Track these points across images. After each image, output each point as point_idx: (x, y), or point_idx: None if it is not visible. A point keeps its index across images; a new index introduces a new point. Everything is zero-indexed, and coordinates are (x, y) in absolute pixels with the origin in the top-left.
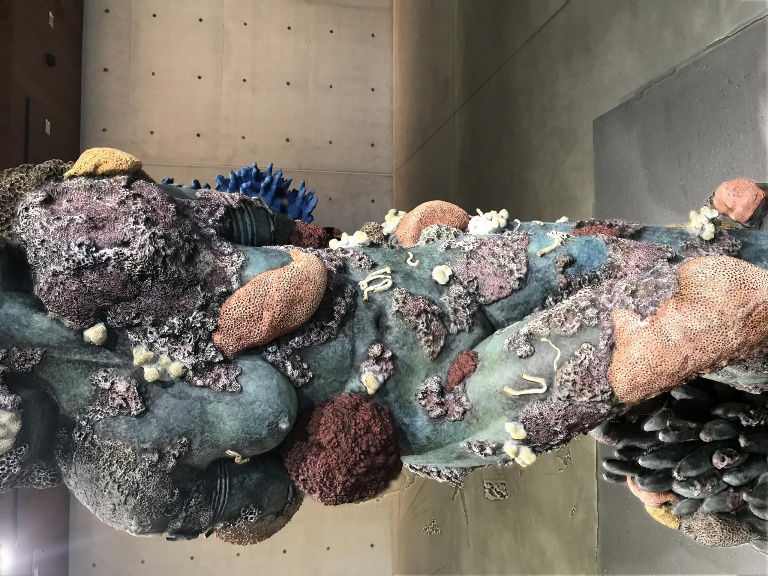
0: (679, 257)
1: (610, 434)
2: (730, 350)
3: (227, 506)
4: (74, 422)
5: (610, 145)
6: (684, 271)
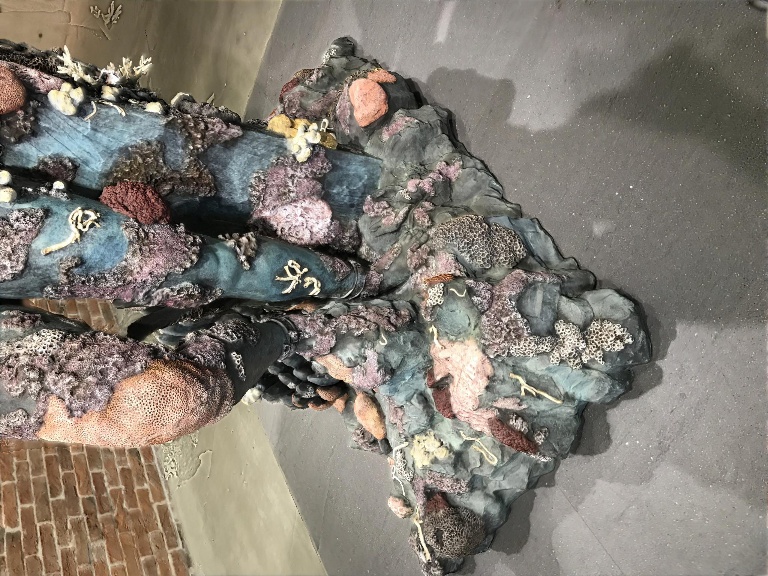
0: (203, 259)
1: None
2: None
3: None
4: None
5: None
6: (120, 389)
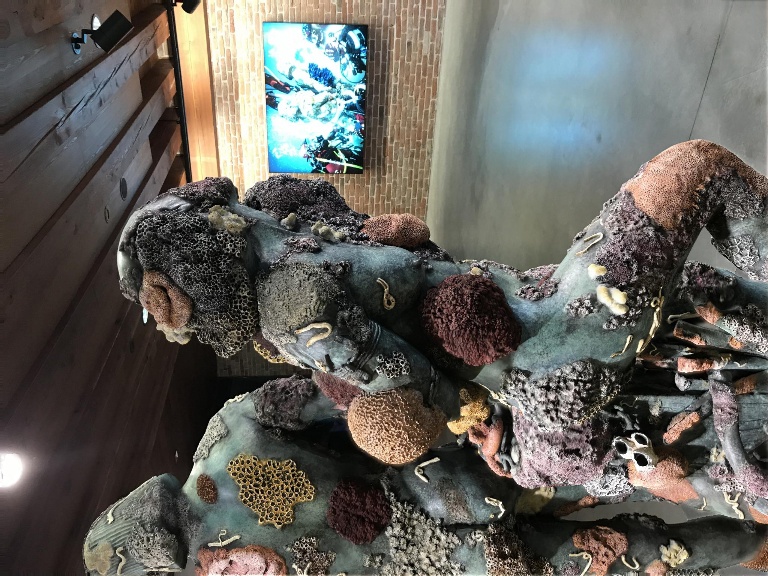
0: None
1: (757, 467)
2: (702, 165)
3: (381, 339)
4: (270, 265)
5: None
6: None
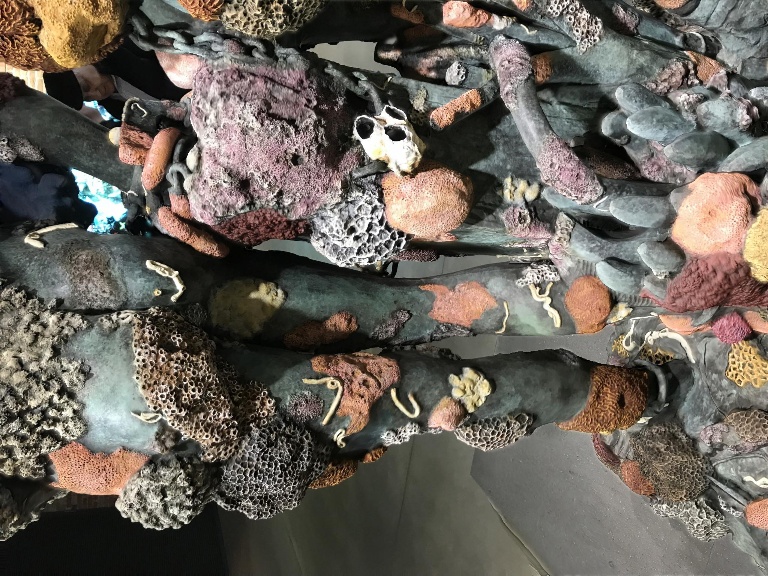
0: None
1: (567, 144)
2: None
3: None
4: None
5: (497, 472)
6: None
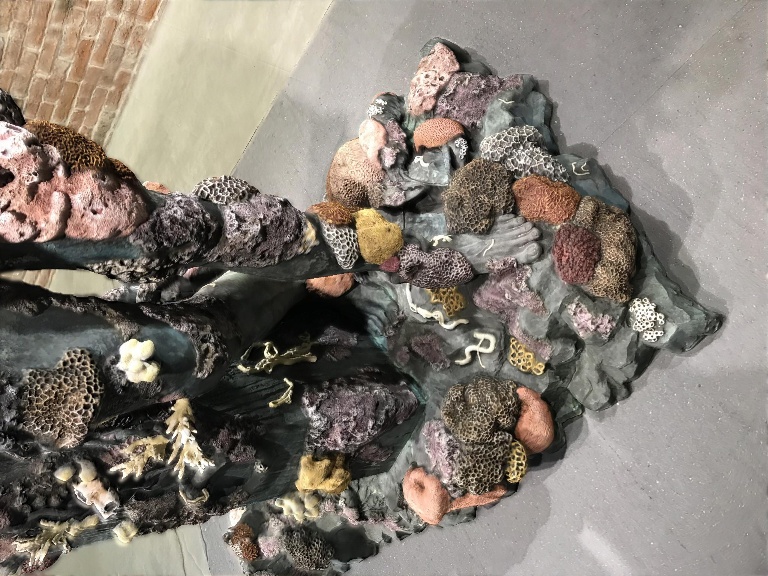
0: None
1: None
2: None
3: None
4: None
5: None
6: None
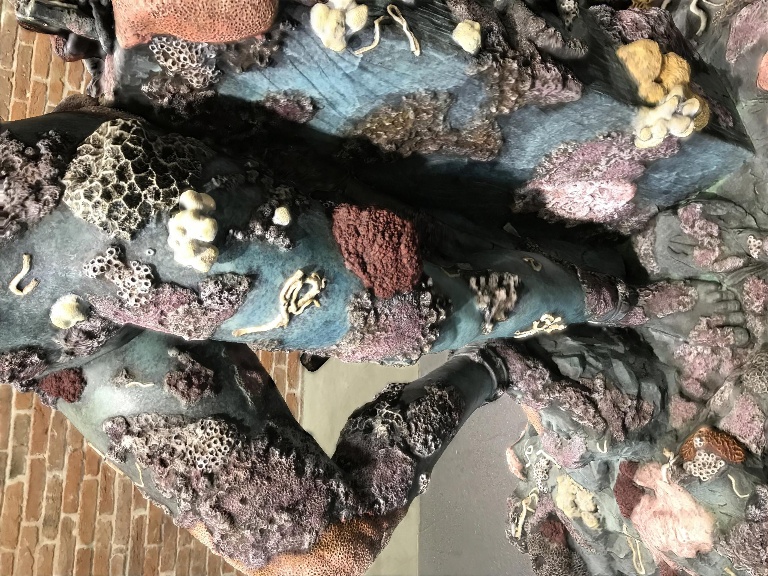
0: (438, 342)
1: None
2: None
3: None
4: None
5: None
6: (276, 565)
